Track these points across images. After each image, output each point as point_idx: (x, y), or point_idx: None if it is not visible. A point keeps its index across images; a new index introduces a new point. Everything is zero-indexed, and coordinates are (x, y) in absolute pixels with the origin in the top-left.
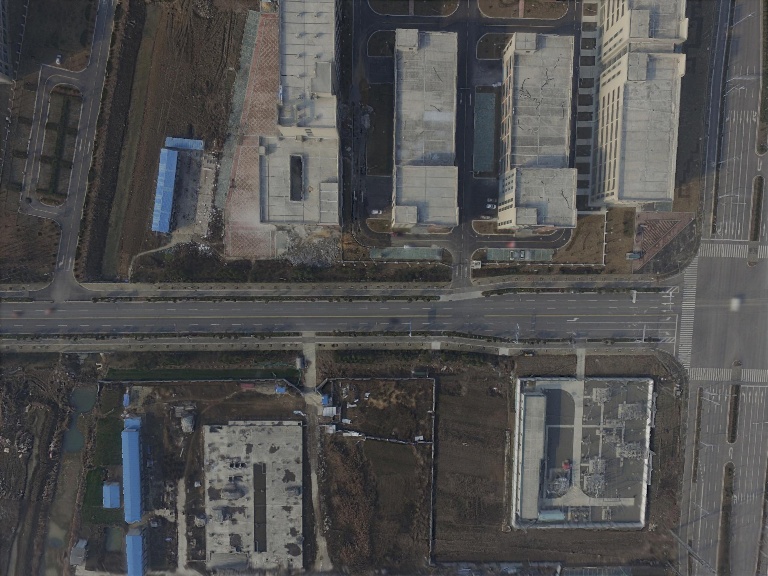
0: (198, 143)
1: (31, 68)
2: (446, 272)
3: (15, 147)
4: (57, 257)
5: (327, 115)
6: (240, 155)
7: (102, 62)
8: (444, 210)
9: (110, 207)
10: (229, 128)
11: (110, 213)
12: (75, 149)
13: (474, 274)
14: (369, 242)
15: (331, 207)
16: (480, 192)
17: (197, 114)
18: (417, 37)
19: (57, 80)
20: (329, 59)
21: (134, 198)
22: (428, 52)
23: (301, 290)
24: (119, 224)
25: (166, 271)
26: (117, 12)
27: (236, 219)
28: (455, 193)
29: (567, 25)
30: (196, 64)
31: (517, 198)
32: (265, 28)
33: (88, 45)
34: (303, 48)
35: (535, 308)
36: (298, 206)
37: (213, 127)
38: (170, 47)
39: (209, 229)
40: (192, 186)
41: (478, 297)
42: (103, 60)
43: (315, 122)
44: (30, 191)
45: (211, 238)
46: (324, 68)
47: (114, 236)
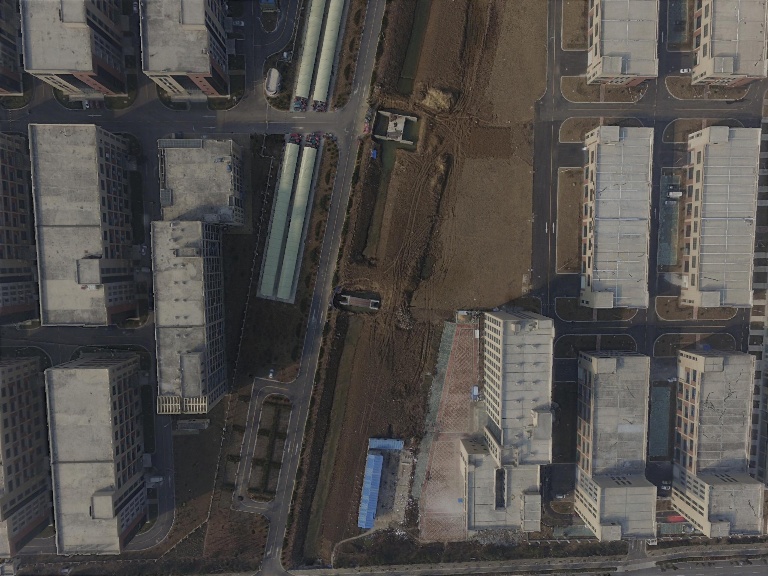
0: (399, 444)
1: (245, 381)
2: (624, 548)
3: (229, 452)
4: (265, 547)
5: (542, 451)
6: (435, 450)
7: (310, 373)
8: (642, 523)
9: (312, 497)
10: (426, 426)
11: (312, 502)
12: (284, 451)
13: (649, 547)
14: (552, 522)
15: (534, 516)
16: (655, 474)
17: (397, 416)
18: (615, 365)
19: (269, 391)
20: (545, 403)
21: (336, 490)
22: (622, 373)
23: (489, 567)
24: (320, 511)
25: (366, 556)
26: (326, 330)
27: (431, 507)
28: (653, 508)
29: (737, 324)
30: (396, 371)
31: (708, 509)
32: (460, 337)
33: (298, 359)
34: (521, 394)
35: (704, 574)
36: (501, 512)
37: (411, 426)
38: (372, 356)
39: (406, 516)
40: (390, 479)
41: (652, 567)
42: (311, 371)
43: (531, 458)
44: (242, 490)
45: (407, 524)
46: (545, 418)
47: (315, 522)
